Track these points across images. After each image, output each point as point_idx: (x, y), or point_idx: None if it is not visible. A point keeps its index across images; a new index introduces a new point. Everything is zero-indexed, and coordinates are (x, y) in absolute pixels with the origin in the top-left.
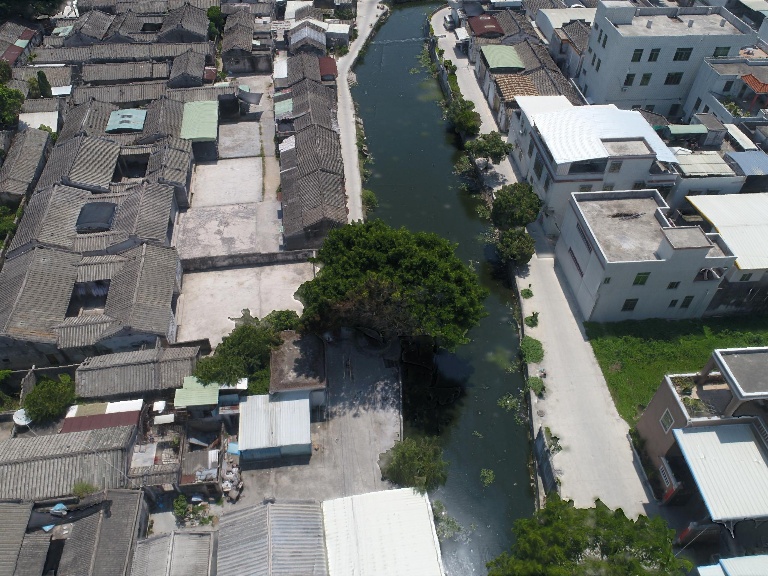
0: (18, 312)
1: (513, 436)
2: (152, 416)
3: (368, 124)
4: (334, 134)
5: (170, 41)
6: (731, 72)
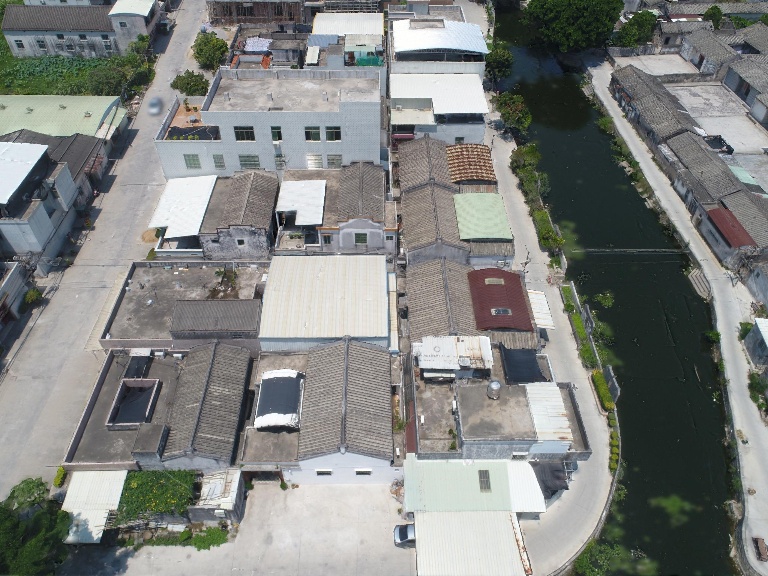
0: (766, 30)
1: None
2: (665, 20)
3: None
4: (662, 133)
5: None
6: None
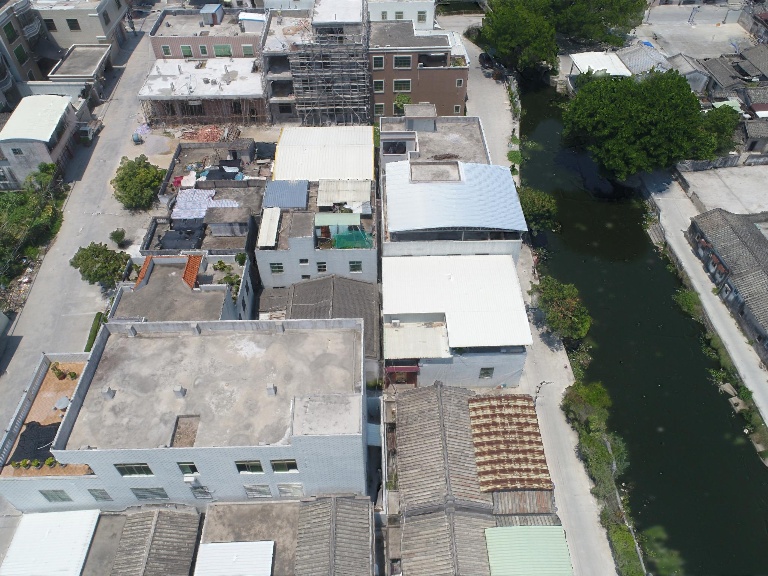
0: None
1: (529, 131)
2: None
3: (762, 491)
4: None
5: None
6: (194, 304)
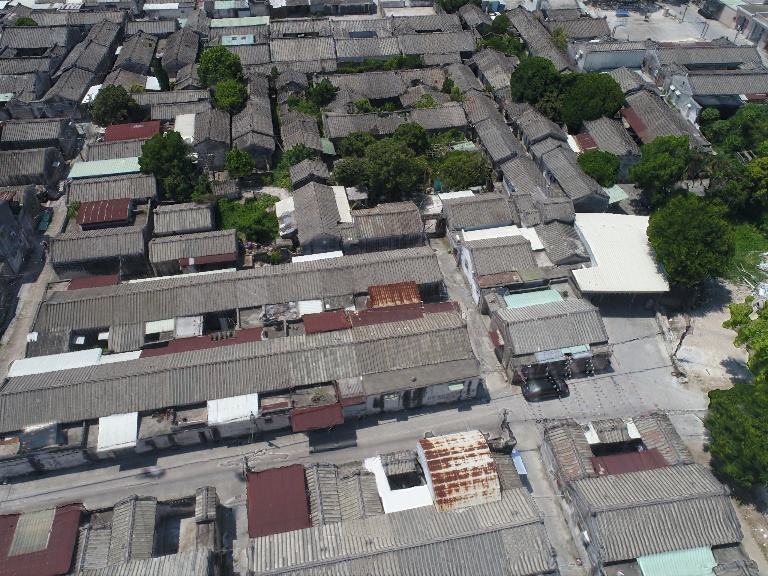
0: None
1: None
2: None
3: None
4: None
5: (70, 45)
6: None
